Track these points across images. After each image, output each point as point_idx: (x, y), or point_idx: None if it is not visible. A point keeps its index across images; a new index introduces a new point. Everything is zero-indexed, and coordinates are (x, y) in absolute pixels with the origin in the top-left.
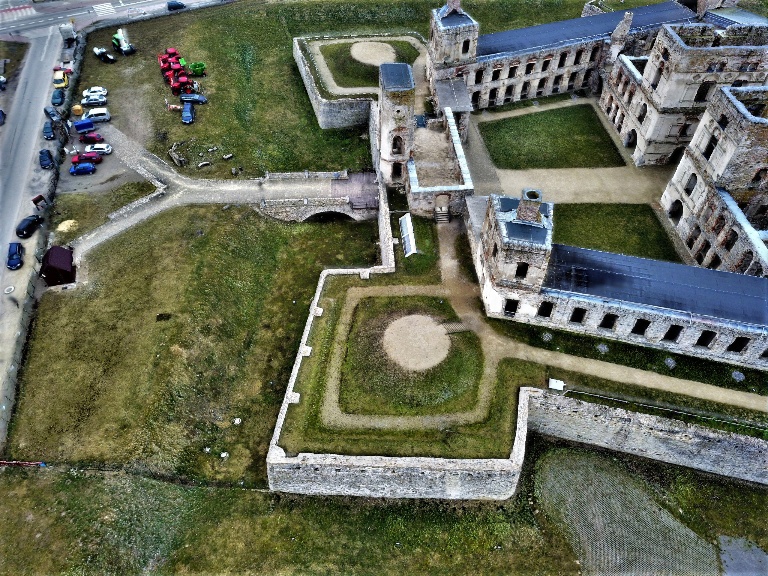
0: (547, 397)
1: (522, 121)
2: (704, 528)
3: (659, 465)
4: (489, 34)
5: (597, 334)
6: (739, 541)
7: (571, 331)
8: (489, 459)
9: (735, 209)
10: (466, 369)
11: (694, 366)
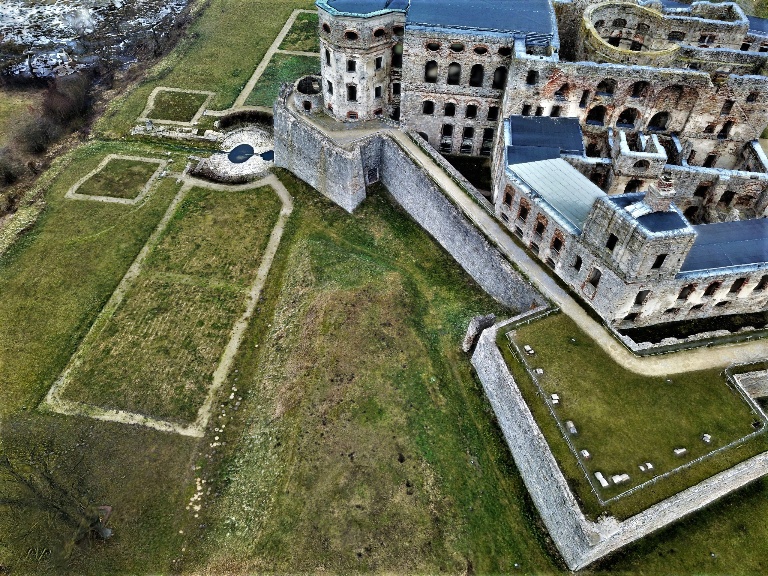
0: None
1: None
2: None
3: None
4: None
5: None
6: None
7: None
8: None
9: None
10: None
11: None
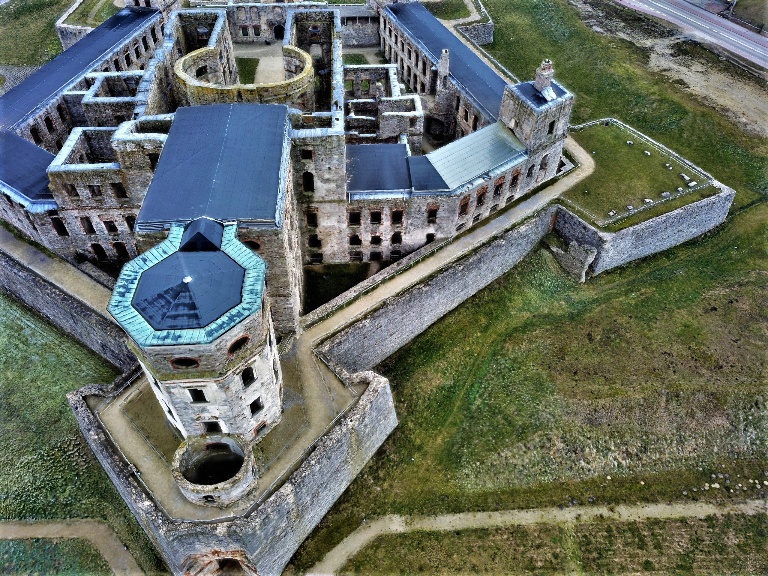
0: None
1: None
2: None
3: None
4: None
5: None
6: None
7: None
8: (64, 19)
9: None
10: None
11: None
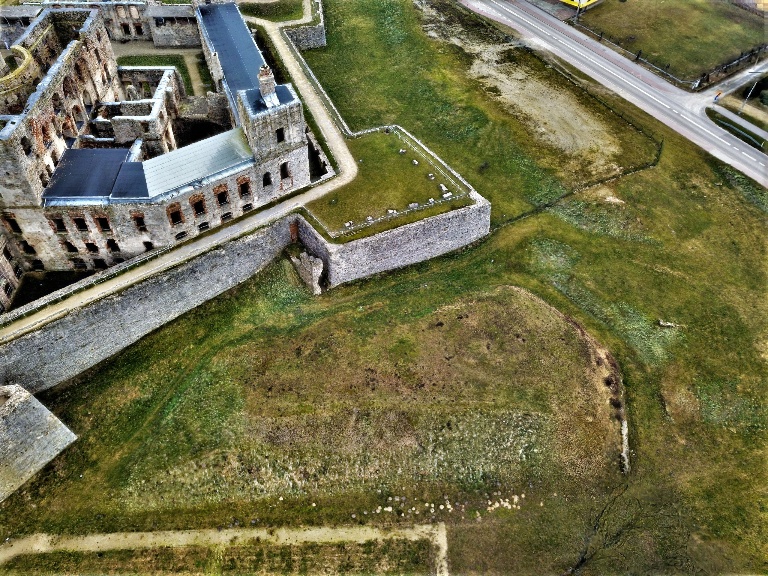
0: None
1: None
2: None
3: None
4: (239, 15)
5: None
6: None
7: None
8: None
9: None
10: None
11: None
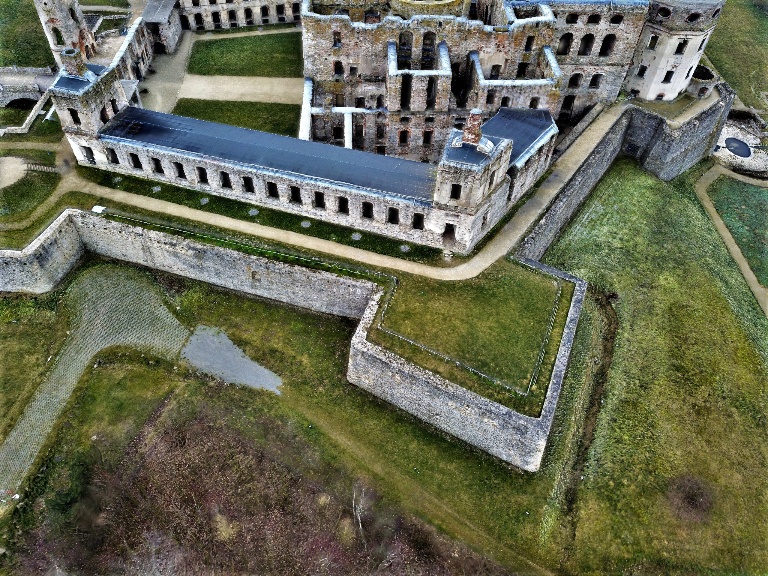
0: (85, 217)
1: (237, 41)
2: (190, 320)
3: (183, 280)
4: None
5: (156, 179)
6: (212, 329)
7: (138, 177)
8: (5, 250)
9: (307, 92)
10: (32, 195)
11: (222, 204)
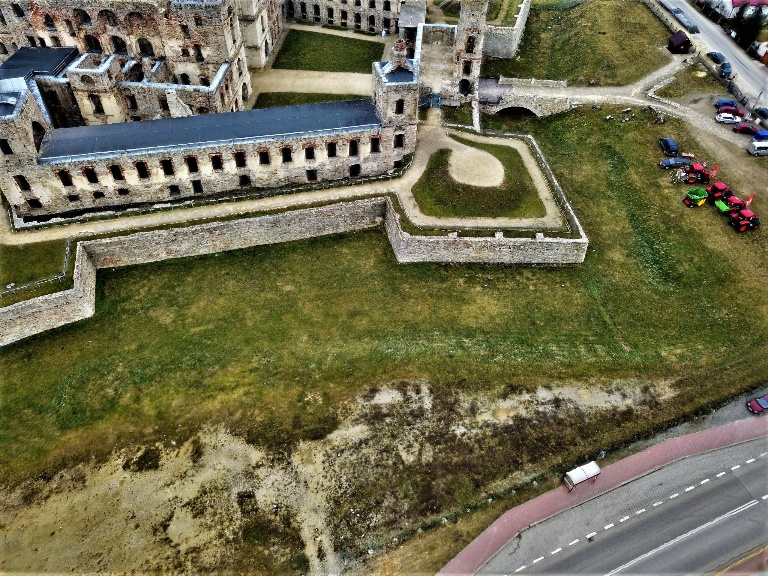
0: None
1: None
2: None
3: None
4: (338, 127)
5: None
6: None
7: None
8: None
9: None
10: None
11: None
